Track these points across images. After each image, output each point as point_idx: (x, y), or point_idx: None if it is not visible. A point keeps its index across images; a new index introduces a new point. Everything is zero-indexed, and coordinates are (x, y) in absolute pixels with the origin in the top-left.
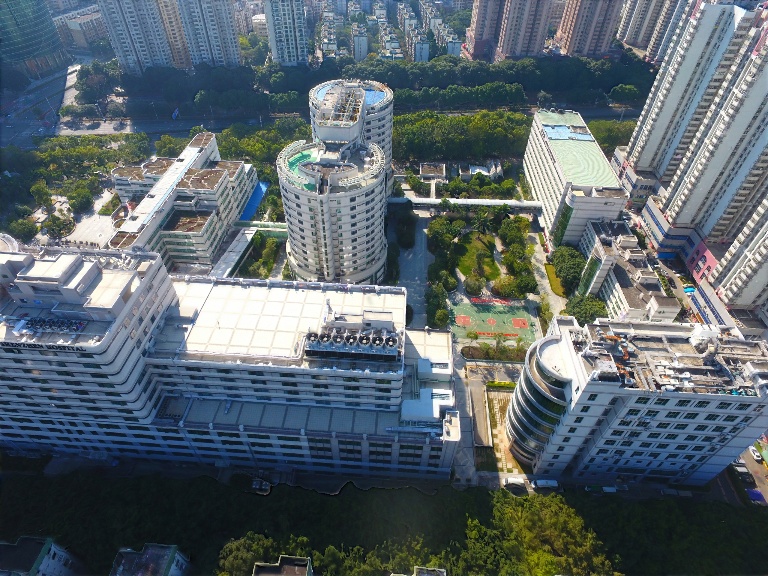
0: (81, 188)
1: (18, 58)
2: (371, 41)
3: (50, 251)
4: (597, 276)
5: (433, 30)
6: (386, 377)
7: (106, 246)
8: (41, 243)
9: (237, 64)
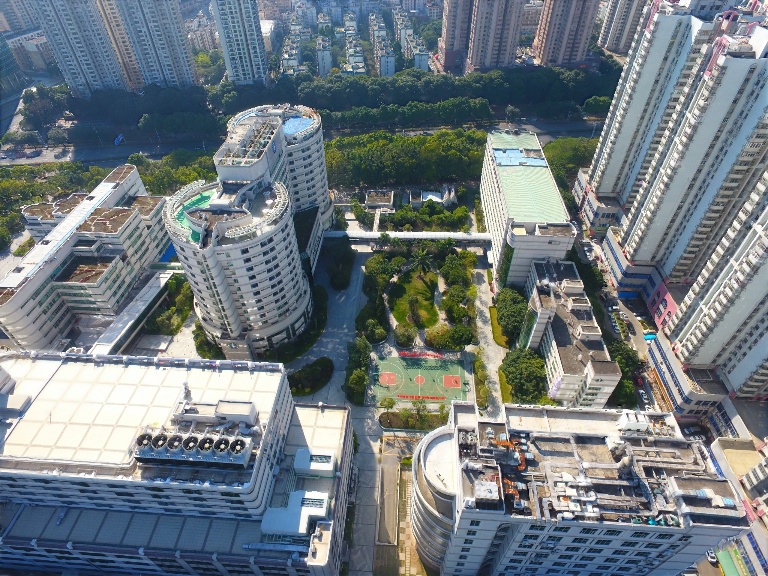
0: None
1: None
2: (338, 54)
3: None
4: (534, 330)
5: (404, 41)
6: (231, 490)
7: None
8: None
9: (192, 83)
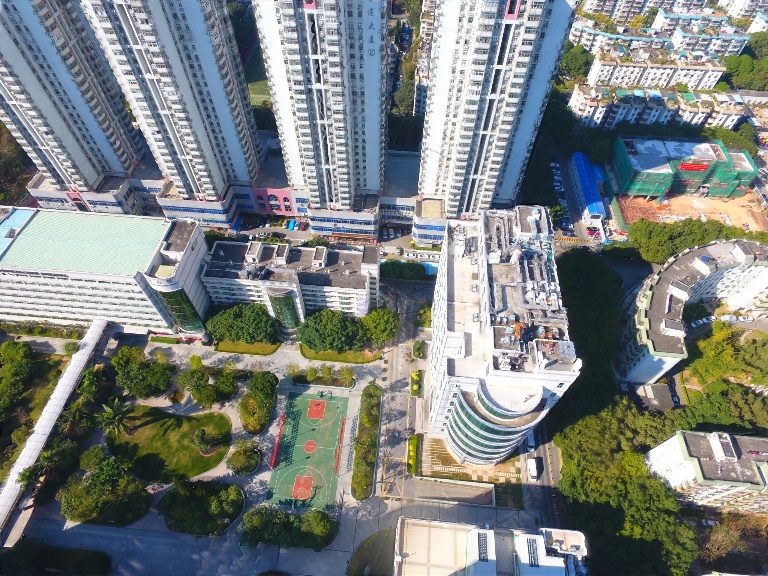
0: None
1: None
2: None
3: None
4: (300, 303)
5: None
6: None
7: None
8: None
9: None
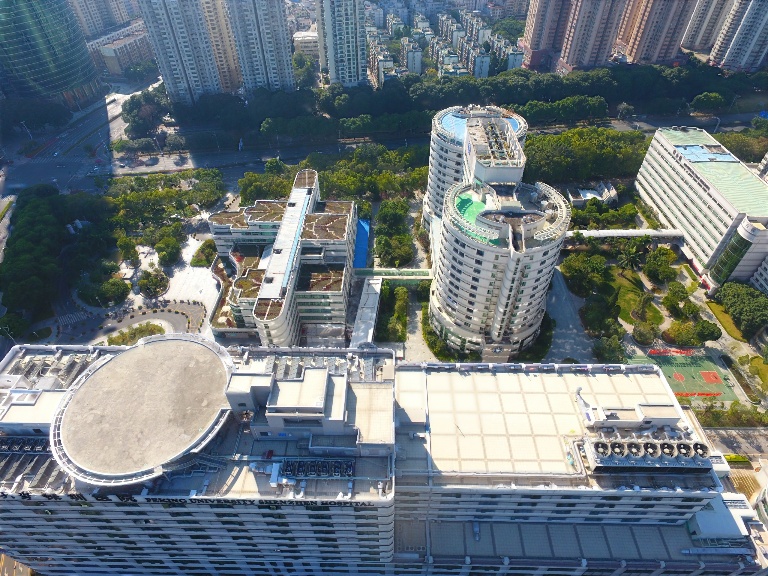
0: (166, 236)
1: (56, 90)
2: None
3: (253, 352)
4: None
5: (482, 41)
6: (700, 495)
7: (216, 306)
8: (137, 304)
9: (292, 87)
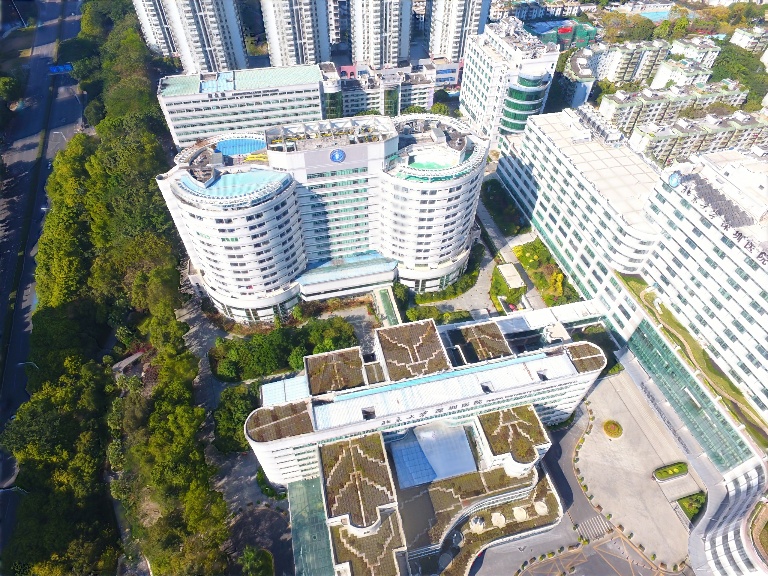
0: None
1: None
2: None
3: None
4: None
5: None
6: None
7: None
8: None
9: None
